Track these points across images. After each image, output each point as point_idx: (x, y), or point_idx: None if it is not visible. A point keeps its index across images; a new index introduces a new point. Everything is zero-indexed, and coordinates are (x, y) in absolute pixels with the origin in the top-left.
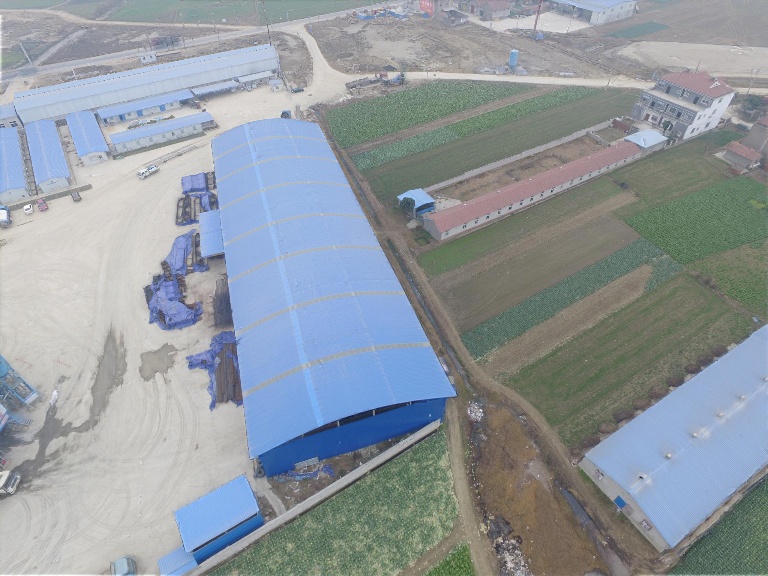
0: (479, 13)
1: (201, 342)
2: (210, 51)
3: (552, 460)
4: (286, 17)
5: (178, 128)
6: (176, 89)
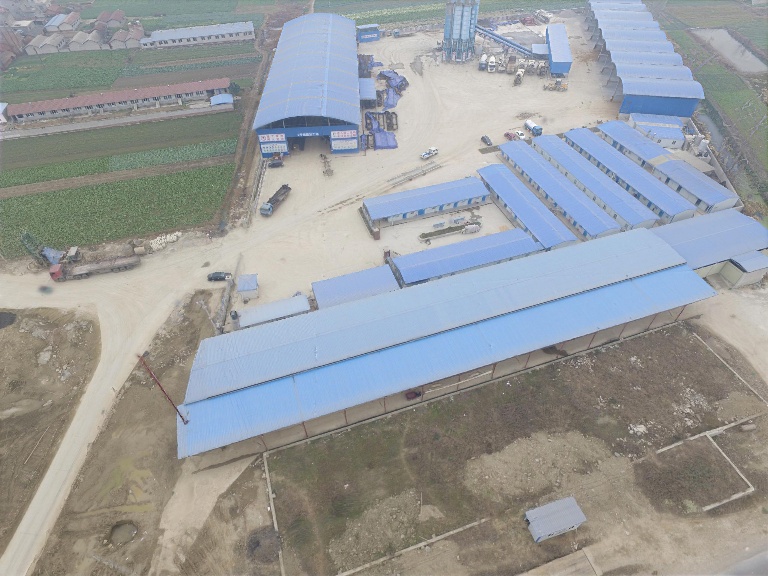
0: None
1: (377, 69)
2: (362, 575)
3: (263, 39)
4: None
5: (406, 191)
6: None
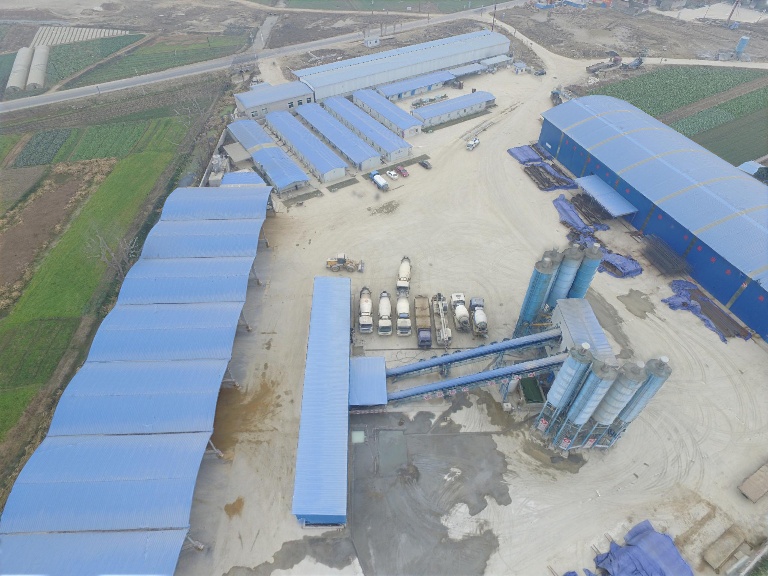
0: (654, 3)
1: (662, 288)
2: (422, 37)
3: None
4: (462, 6)
5: (470, 105)
6: (430, 71)
